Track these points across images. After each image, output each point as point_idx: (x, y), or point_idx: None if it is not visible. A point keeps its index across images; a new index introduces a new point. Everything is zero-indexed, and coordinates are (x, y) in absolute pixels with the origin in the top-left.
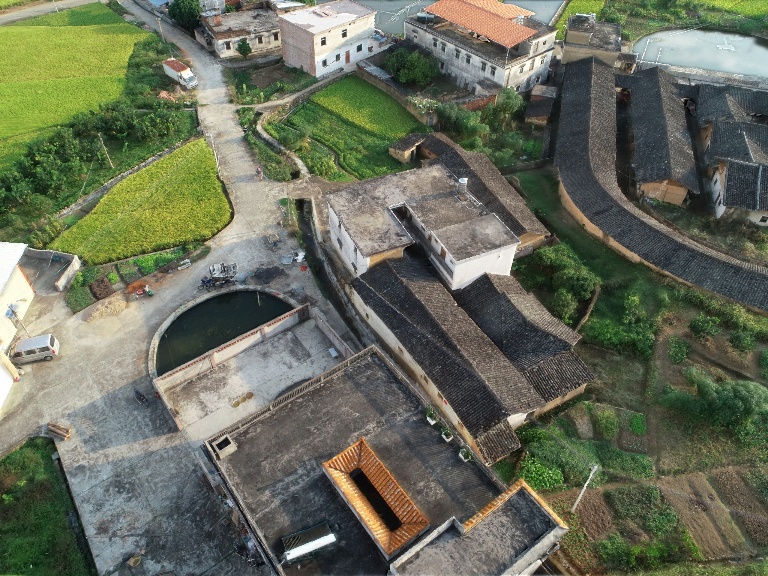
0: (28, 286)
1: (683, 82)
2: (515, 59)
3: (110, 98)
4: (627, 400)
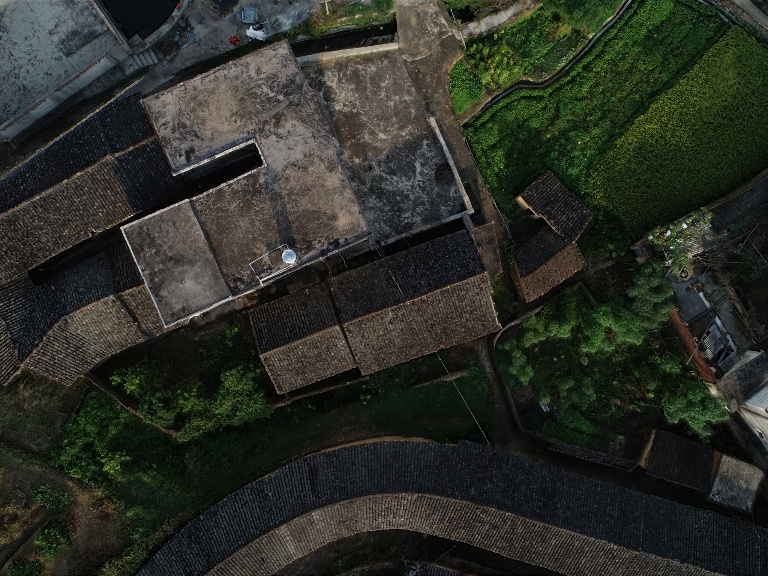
0: None
1: None
2: None
3: None
4: None
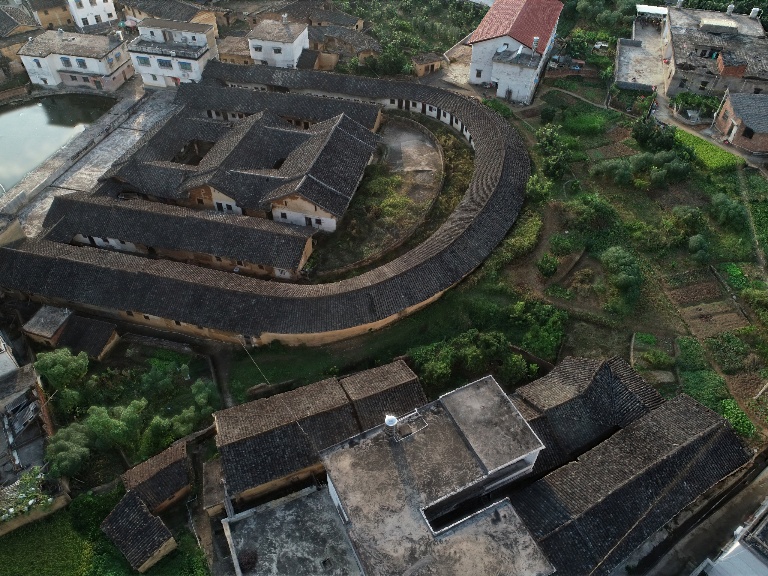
0: None
1: (55, 192)
2: None
3: None
4: (620, 341)
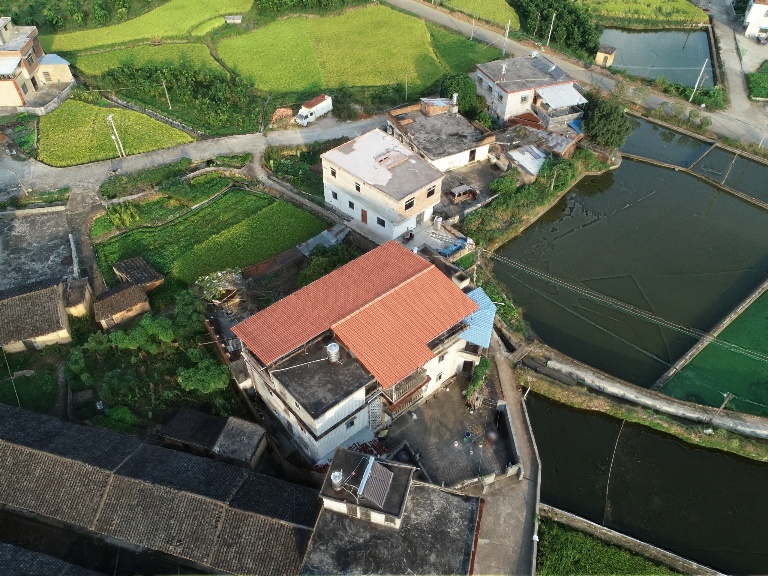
0: (19, 98)
1: None
2: (257, 362)
3: (278, 88)
4: None
